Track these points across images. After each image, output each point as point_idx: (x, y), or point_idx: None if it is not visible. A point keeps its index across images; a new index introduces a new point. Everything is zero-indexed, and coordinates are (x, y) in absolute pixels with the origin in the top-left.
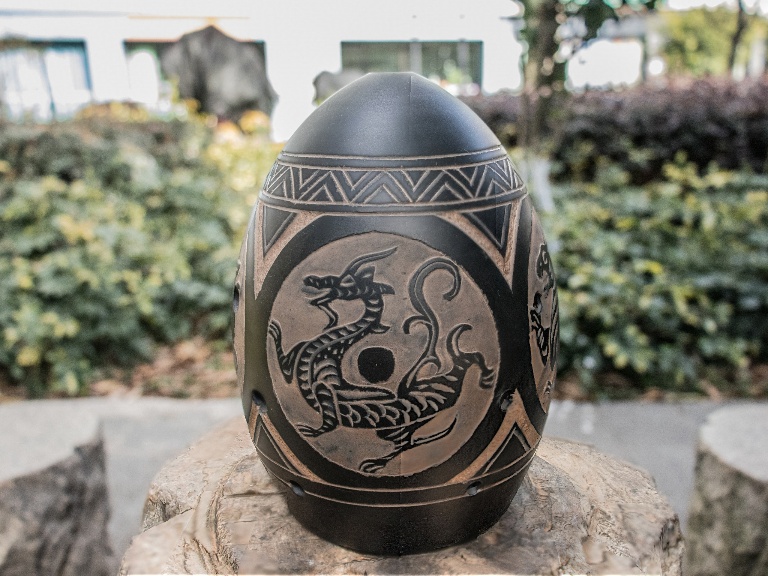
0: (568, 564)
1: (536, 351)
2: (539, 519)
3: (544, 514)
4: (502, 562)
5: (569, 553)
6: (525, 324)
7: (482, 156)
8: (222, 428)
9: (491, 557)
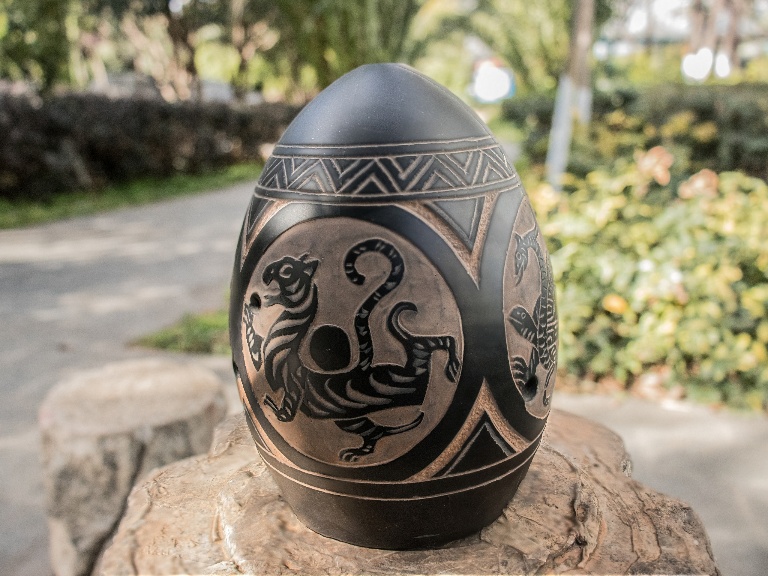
0: (237, 570)
1: (247, 346)
2: (306, 561)
3: (313, 568)
4: (254, 522)
5: (249, 573)
6: (240, 311)
7: (287, 150)
8: (560, 413)
9: (265, 518)
